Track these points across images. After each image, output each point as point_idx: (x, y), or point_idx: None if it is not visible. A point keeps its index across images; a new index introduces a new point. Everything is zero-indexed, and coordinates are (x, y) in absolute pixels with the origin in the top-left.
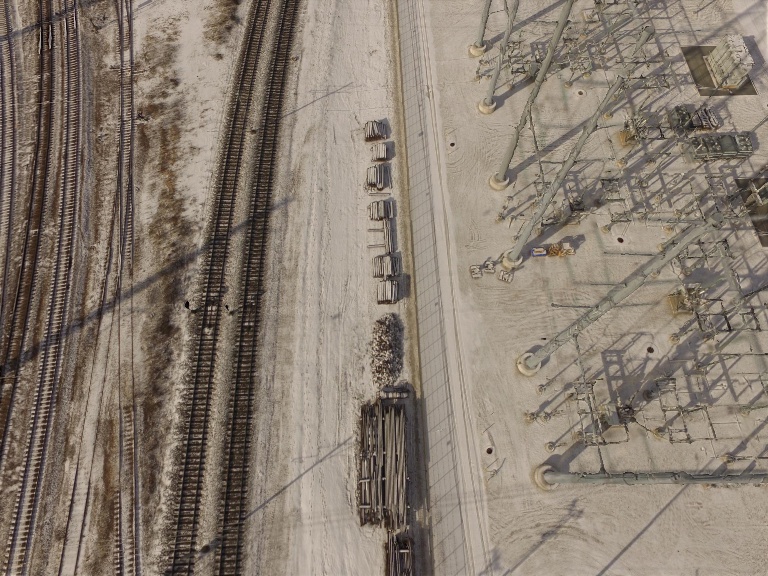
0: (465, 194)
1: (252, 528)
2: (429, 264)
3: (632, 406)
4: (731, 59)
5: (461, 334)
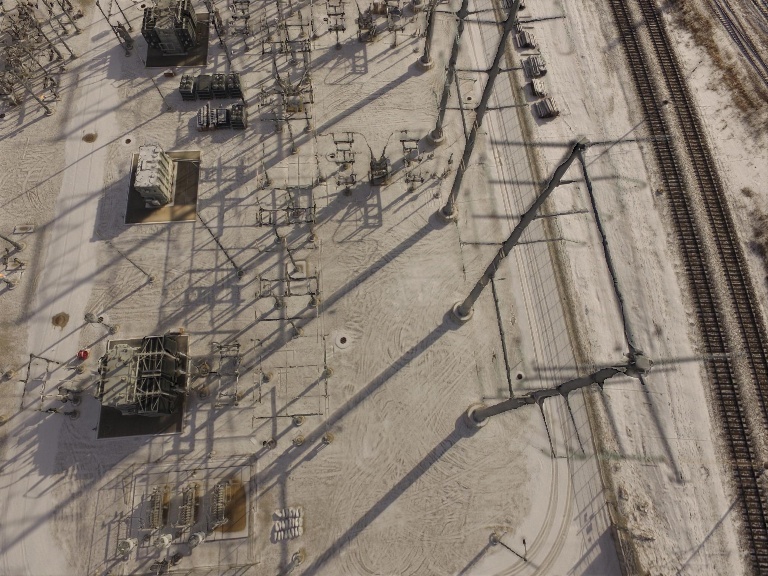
0: None
1: None
2: (481, 4)
3: None
4: None
5: None
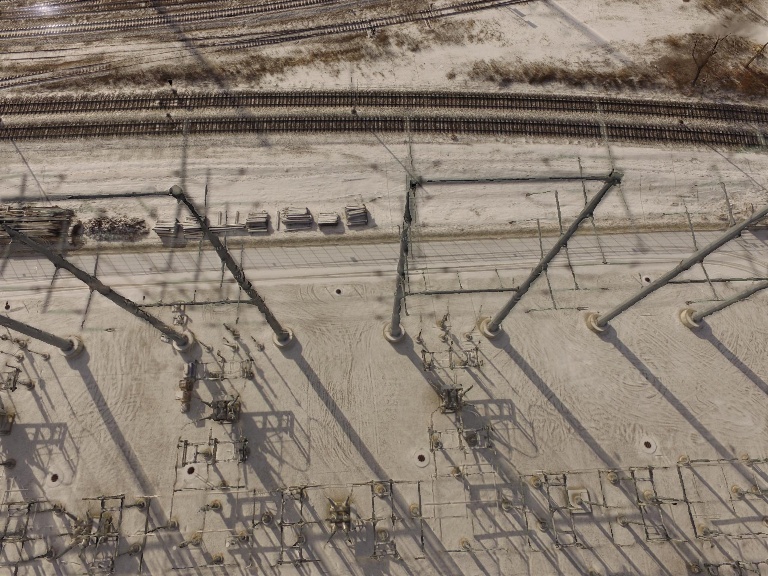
0: (271, 301)
1: (5, 145)
2: (193, 264)
3: (5, 445)
4: None
5: (117, 290)
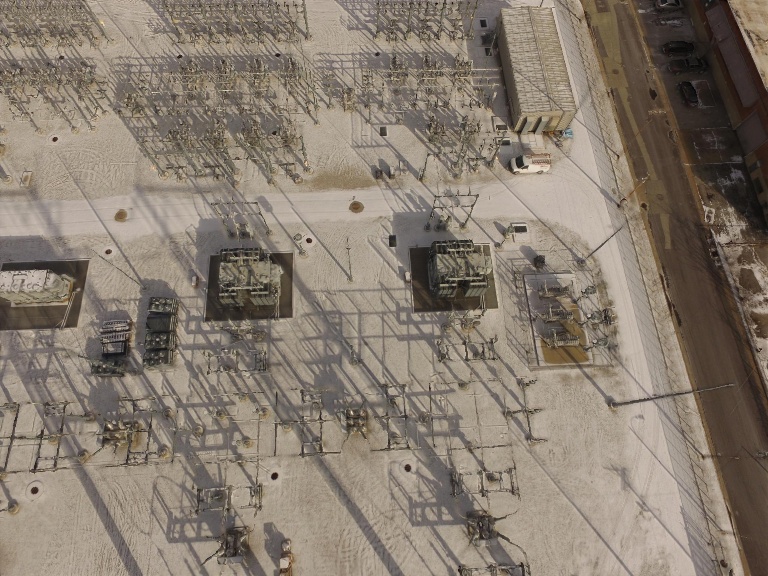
0: None
1: None
2: None
3: (468, 501)
4: (32, 293)
5: None
